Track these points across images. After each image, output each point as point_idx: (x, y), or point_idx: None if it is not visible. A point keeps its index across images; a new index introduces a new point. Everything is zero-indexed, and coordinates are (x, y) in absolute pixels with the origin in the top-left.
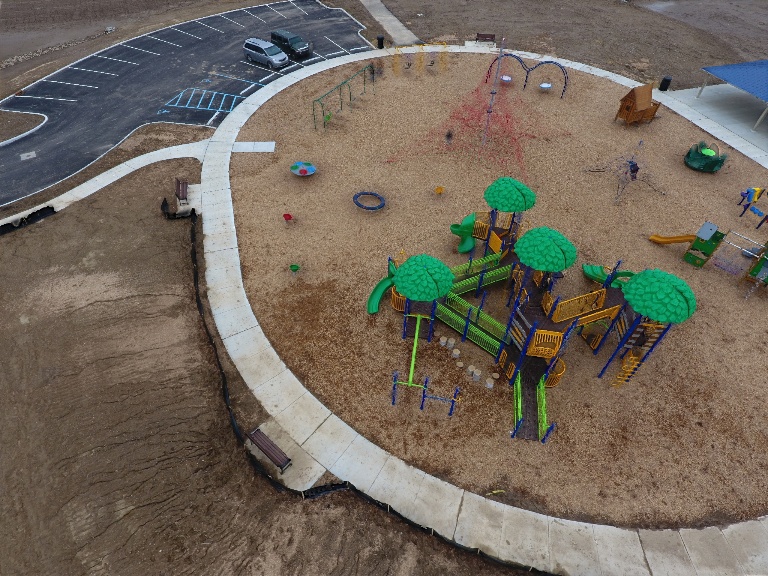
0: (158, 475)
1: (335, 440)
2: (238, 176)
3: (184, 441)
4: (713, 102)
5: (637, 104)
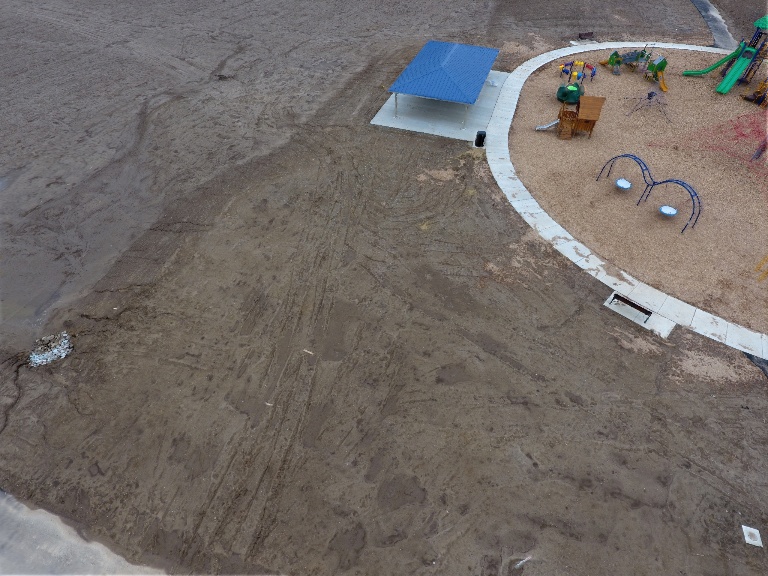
0: None
1: None
2: None
3: None
4: (457, 122)
5: None
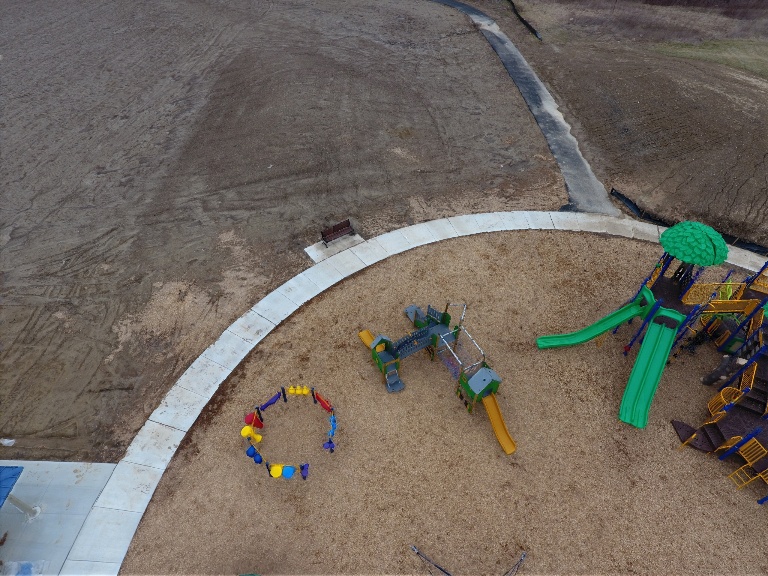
0: None
1: None
2: None
3: None
4: None
5: None
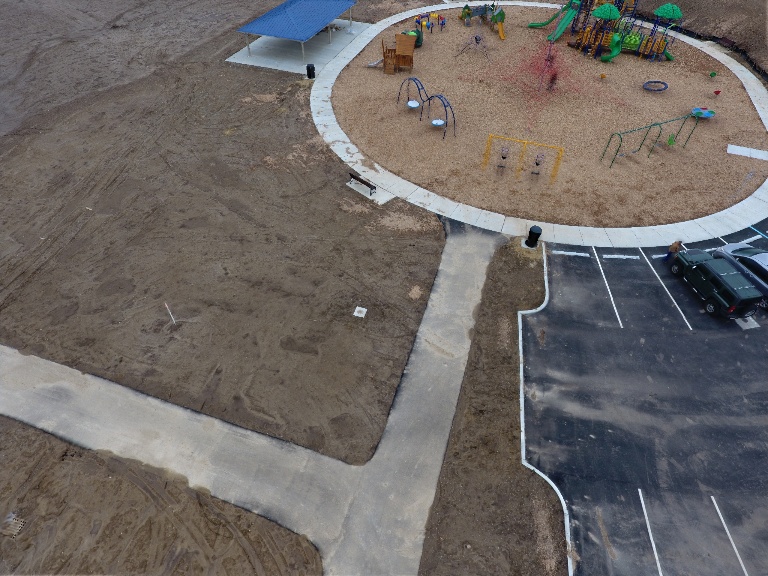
0: (767, 42)
1: (697, 44)
2: (760, 133)
3: (759, 49)
4: None
5: None
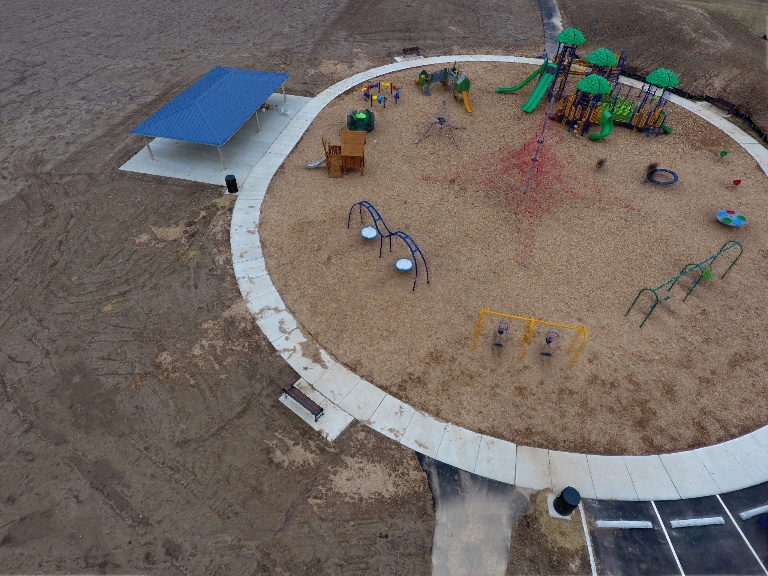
0: None
1: None
2: None
3: (763, 113)
4: None
5: None
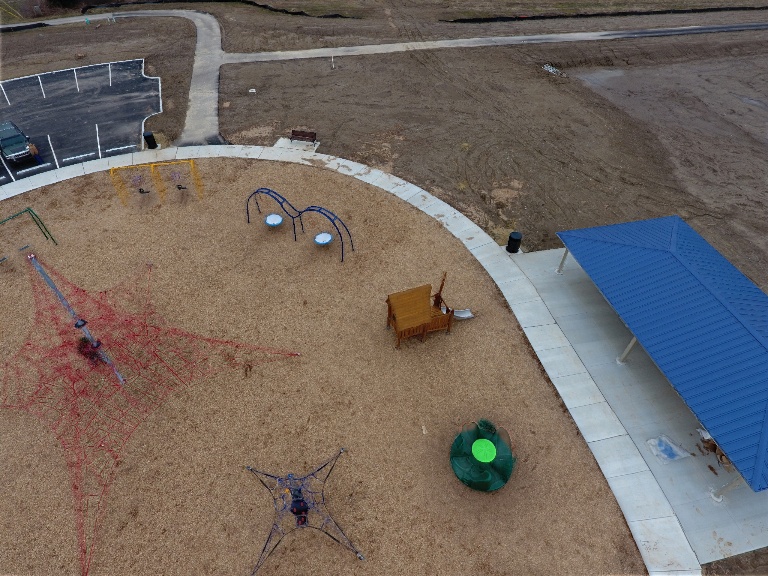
0: None
1: None
2: None
3: None
4: (581, 283)
5: (399, 319)
